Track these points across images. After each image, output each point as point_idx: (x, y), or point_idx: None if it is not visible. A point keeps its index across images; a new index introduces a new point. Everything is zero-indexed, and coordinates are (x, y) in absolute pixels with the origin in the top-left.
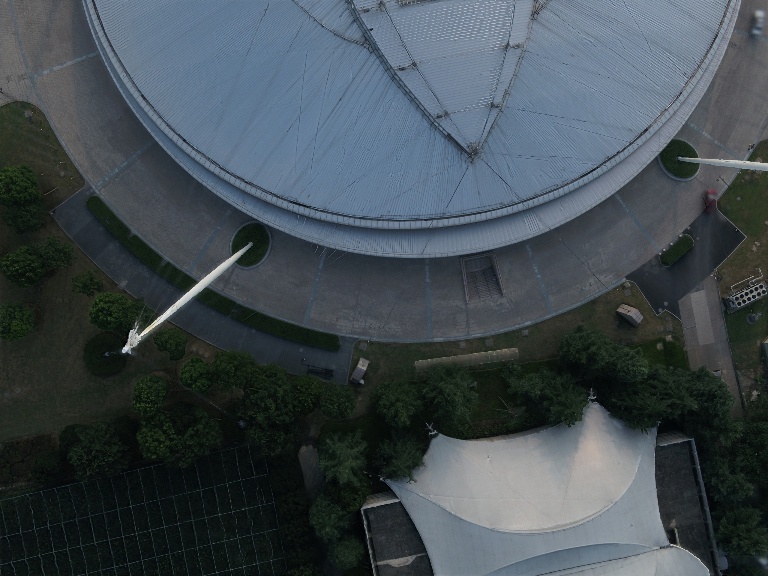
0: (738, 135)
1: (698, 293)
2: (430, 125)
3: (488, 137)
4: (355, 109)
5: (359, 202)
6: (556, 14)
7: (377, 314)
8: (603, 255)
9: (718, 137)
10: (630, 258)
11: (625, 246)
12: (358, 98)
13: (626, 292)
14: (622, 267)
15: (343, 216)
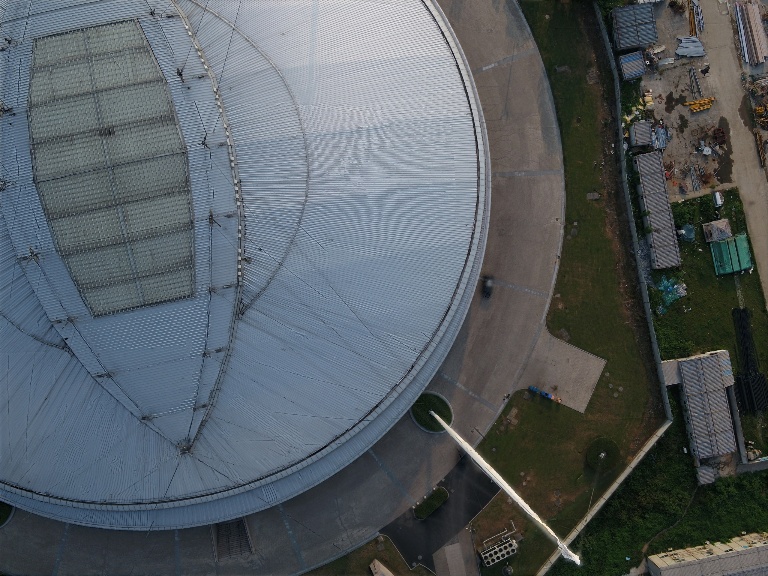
0: (493, 385)
1: (453, 546)
2: (140, 421)
3: (202, 430)
4: (62, 407)
5: (84, 484)
6: (263, 312)
7: (125, 574)
8: (356, 510)
9: (472, 388)
10: (383, 512)
11: (378, 500)
12: (63, 398)
13: (379, 547)
14: (375, 521)
15: (66, 500)
